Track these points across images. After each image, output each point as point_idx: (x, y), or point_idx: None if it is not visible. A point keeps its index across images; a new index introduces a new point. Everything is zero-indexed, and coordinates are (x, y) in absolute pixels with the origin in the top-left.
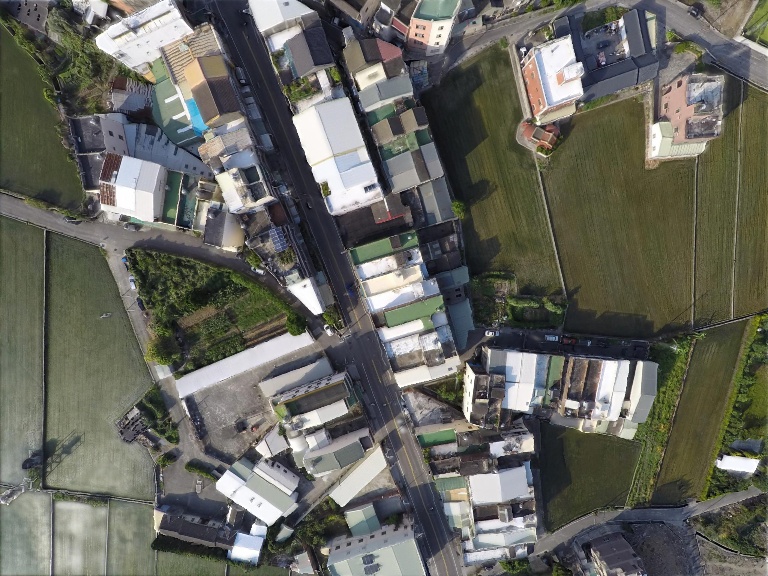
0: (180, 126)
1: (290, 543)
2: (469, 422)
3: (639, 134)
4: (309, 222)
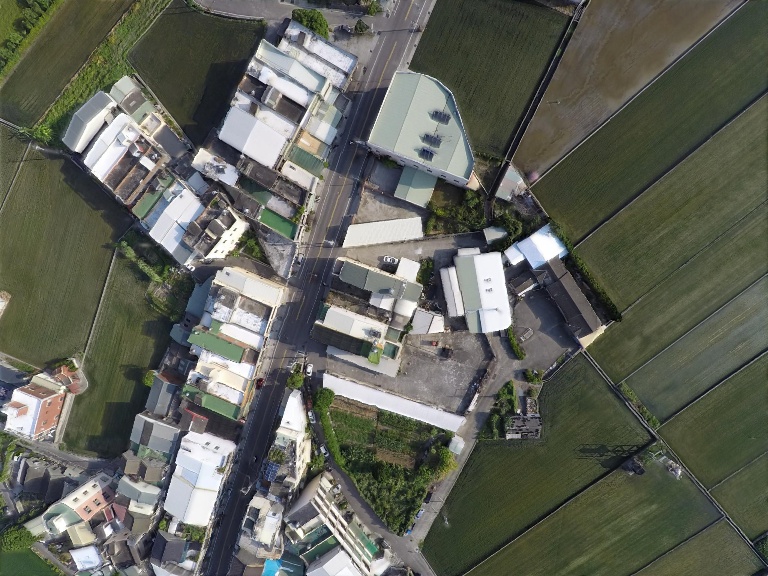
0: (289, 573)
1: (501, 218)
2: (237, 221)
3: (4, 323)
4: (264, 450)
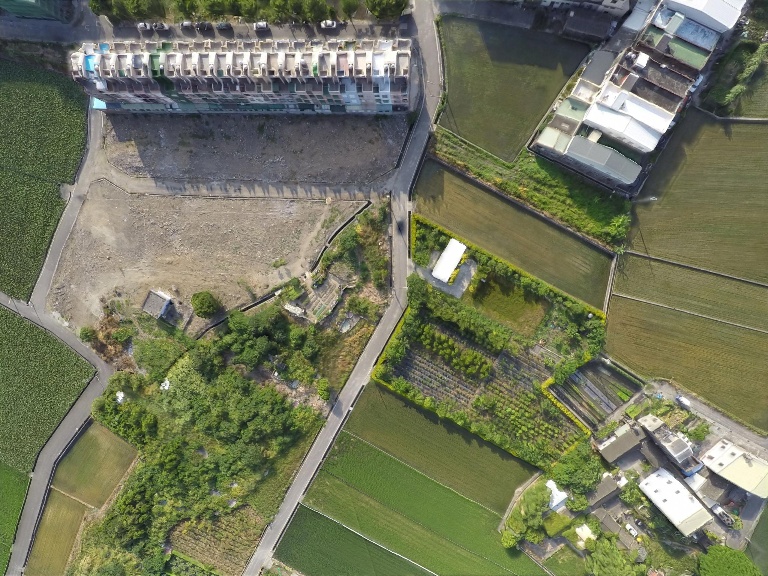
0: None
1: None
2: None
3: None
4: None
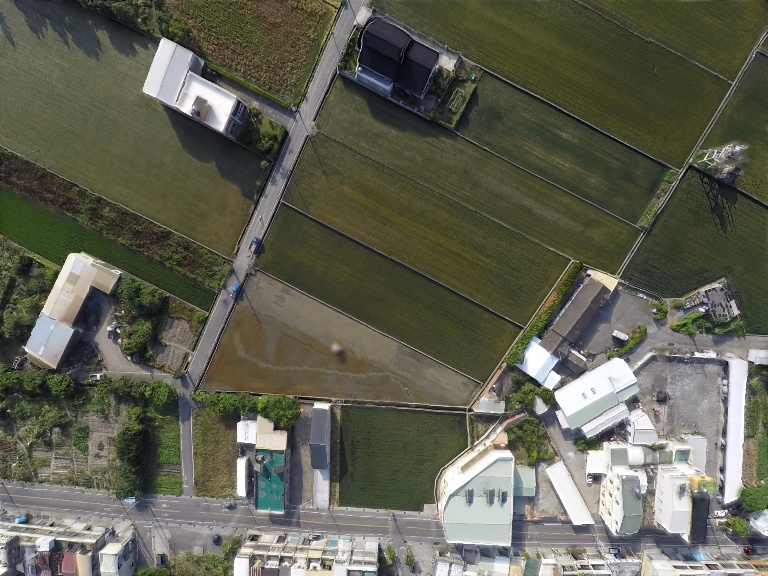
0: None
1: (521, 403)
2: None
3: None
4: None
